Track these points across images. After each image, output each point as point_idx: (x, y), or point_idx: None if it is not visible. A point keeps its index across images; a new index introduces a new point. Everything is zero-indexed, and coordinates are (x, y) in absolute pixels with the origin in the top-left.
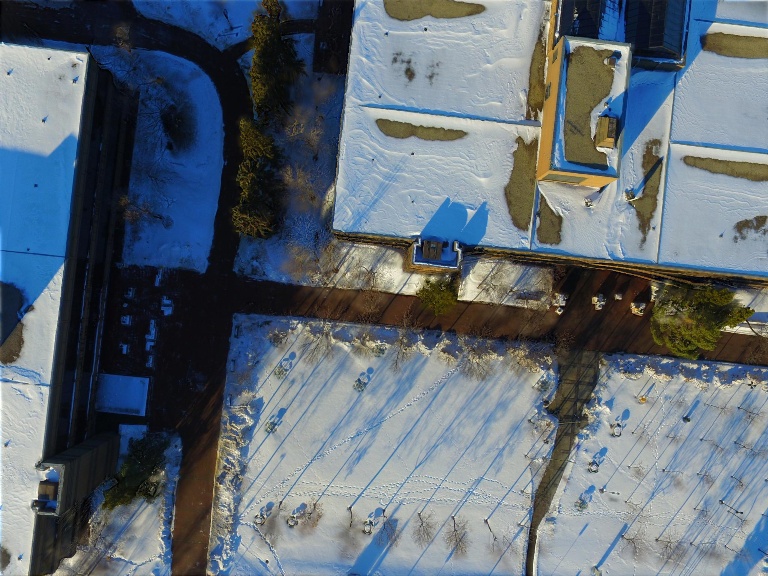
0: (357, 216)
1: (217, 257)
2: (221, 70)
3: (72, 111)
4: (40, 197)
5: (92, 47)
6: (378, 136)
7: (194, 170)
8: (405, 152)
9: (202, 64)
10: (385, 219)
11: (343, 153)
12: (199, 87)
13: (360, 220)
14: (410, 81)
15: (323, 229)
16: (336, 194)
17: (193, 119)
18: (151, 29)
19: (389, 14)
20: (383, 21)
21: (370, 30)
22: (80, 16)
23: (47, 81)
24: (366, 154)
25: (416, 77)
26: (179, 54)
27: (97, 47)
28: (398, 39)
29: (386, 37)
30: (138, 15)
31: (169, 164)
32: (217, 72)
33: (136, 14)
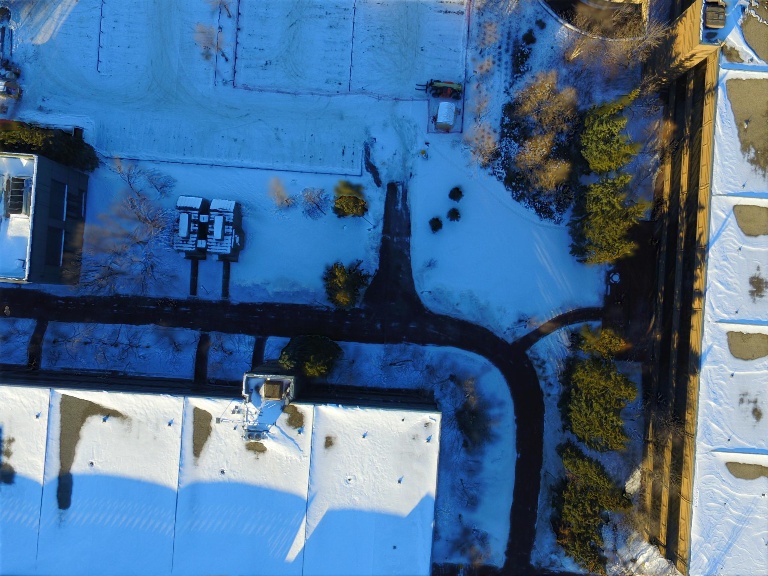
0: (713, 563)
1: (514, 550)
2: (510, 362)
3: (427, 471)
4: (399, 559)
5: (383, 346)
6: (729, 479)
7: (490, 466)
8: (756, 494)
9: (492, 357)
10: (740, 564)
11: (697, 500)
12: (490, 381)
13: (716, 566)
14: (758, 421)
15: (622, 521)
16: (691, 541)
17: (486, 414)
18: (440, 325)
19: (734, 355)
20: (728, 362)
21: (716, 373)
22: (370, 315)
23: (401, 441)
24: (718, 499)
25: (763, 417)
26: (468, 348)
27: (388, 346)
28: (744, 379)
29: (732, 378)
30: (426, 311)
31: (466, 462)
32: (507, 365)
33: (424, 310)
